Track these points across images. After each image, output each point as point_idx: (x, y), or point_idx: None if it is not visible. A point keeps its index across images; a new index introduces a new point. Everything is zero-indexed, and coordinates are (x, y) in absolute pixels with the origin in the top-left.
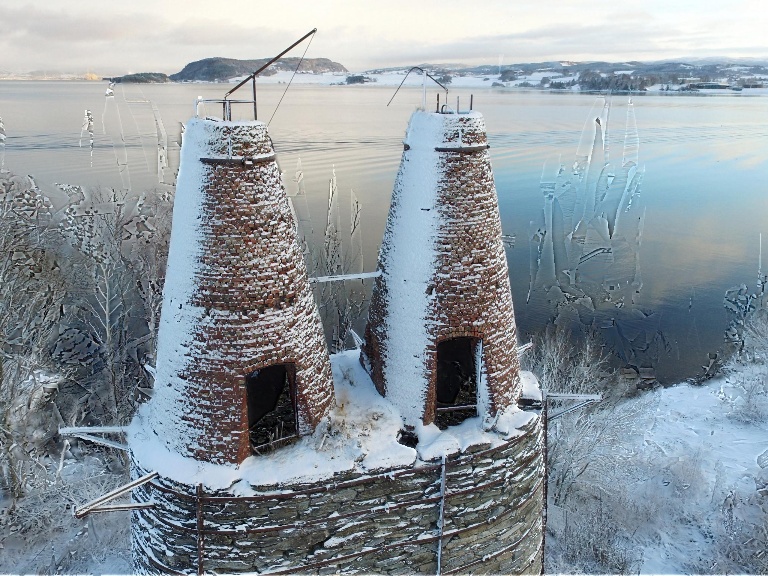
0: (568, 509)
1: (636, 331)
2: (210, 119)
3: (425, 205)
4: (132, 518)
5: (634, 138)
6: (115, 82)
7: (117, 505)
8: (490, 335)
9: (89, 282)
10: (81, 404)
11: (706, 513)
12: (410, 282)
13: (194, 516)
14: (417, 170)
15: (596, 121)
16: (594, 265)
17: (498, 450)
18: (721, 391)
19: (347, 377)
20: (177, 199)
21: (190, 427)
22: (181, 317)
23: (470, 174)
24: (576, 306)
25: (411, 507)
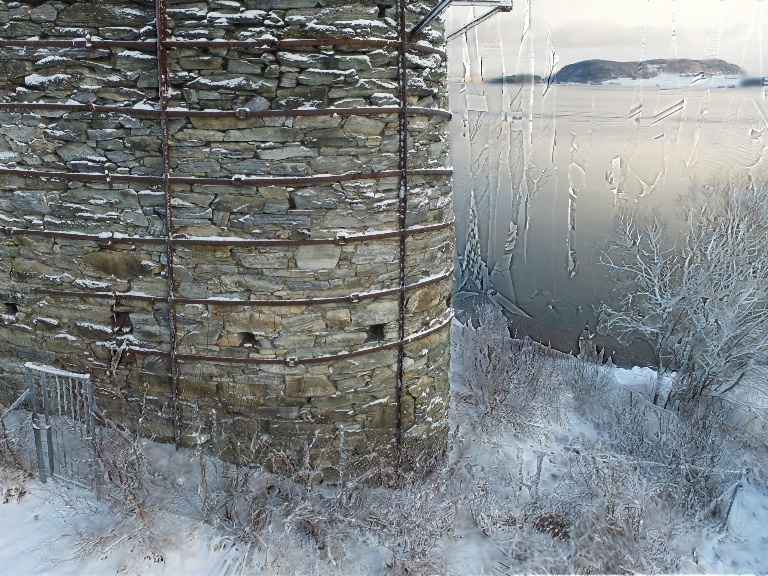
0: None
1: None
2: None
3: None
4: None
5: None
6: None
7: None
8: None
9: None
10: None
11: None
12: None
13: None
14: None
15: None
16: None
17: None
18: None
19: None
20: None
21: None
22: None
23: None
24: None
25: (123, 52)
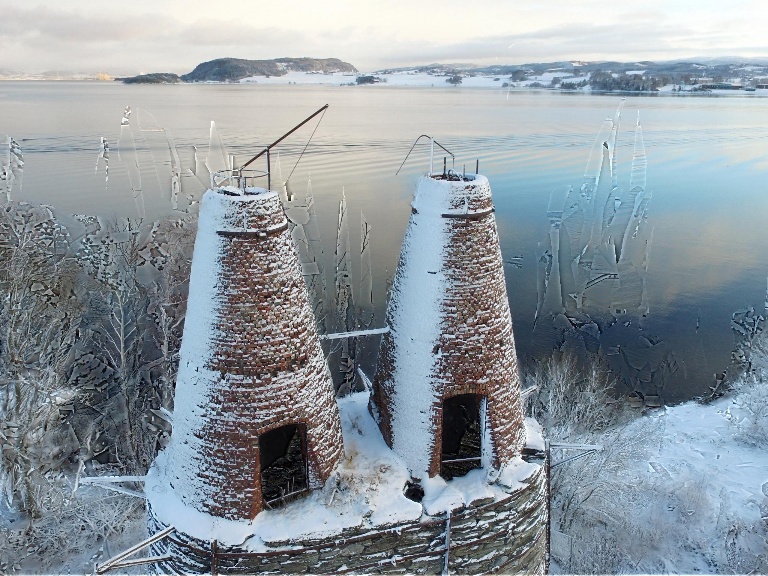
0: (573, 534)
1: (642, 359)
2: (226, 192)
3: (432, 268)
4: (149, 565)
5: (642, 160)
6: (130, 111)
7: (136, 560)
8: (494, 392)
9: (104, 308)
10: (96, 425)
11: (710, 540)
12: (417, 341)
13: (209, 569)
14: (424, 235)
15: (604, 145)
16: (601, 290)
17: (501, 503)
18: (728, 412)
19: (356, 426)
20: (194, 267)
21: (205, 484)
22: (197, 380)
23: (475, 239)
24: (582, 333)
25: (417, 559)
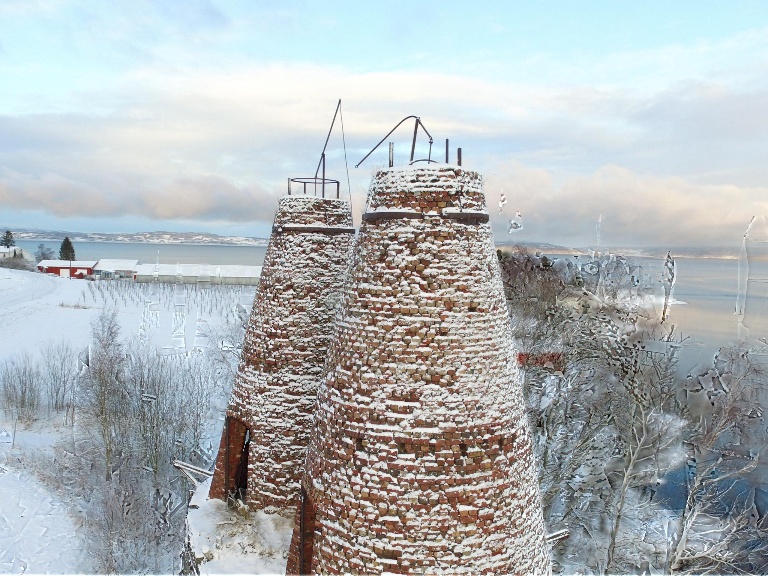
0: None
1: None
2: None
3: None
4: None
5: None
6: None
7: None
8: (327, 518)
9: (629, 420)
10: None
11: None
12: None
13: None
14: None
15: None
16: None
17: None
18: None
19: None
20: None
21: None
22: None
23: None
24: None
25: None
